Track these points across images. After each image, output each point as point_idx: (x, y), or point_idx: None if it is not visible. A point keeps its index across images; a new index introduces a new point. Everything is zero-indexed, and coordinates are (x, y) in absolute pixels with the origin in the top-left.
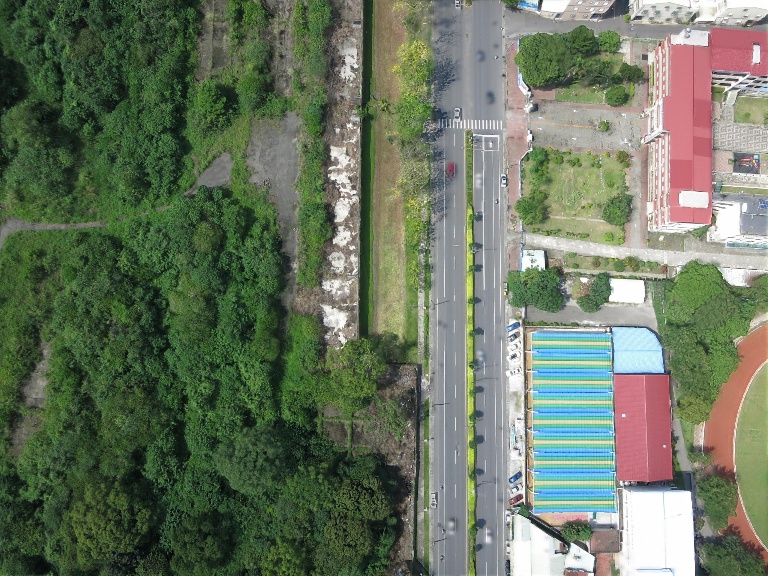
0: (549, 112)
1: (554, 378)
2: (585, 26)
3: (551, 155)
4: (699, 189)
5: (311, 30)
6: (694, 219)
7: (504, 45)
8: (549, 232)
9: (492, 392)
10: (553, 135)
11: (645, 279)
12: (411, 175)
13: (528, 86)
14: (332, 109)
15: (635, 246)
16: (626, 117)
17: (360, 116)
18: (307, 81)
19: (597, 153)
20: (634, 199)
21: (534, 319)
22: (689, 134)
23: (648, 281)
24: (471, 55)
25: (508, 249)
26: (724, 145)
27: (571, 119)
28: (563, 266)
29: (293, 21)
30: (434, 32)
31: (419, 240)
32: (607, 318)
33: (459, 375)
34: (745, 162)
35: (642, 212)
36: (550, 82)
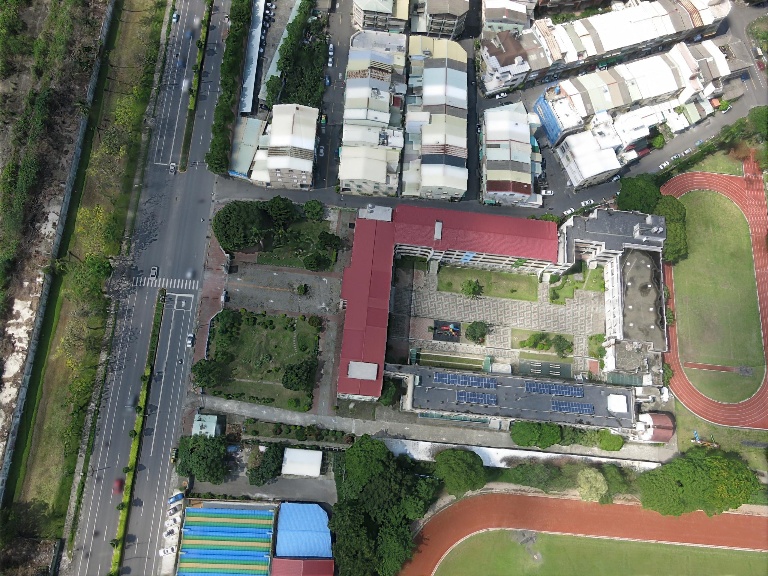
0: (249, 274)
1: (204, 561)
2: (279, 197)
3: (244, 316)
4: (369, 360)
5: (17, 188)
6: (360, 391)
7: (212, 209)
8: (231, 396)
9: (140, 574)
10: (250, 297)
11: (328, 449)
12: (68, 335)
13: (224, 249)
14: (24, 263)
15: (322, 413)
16: (327, 282)
17: (44, 272)
18: (4, 235)
19: (293, 316)
20: (326, 364)
21: (201, 490)
22: (364, 304)
23: (328, 452)
24: (177, 217)
25: (185, 412)
26: (425, 313)
27: (270, 282)
28: (241, 432)
29: (2, 179)
30: (144, 194)
31: (90, 400)
32: (283, 491)
33: (106, 553)
34: (443, 331)
35: (333, 378)
36: (243, 247)
